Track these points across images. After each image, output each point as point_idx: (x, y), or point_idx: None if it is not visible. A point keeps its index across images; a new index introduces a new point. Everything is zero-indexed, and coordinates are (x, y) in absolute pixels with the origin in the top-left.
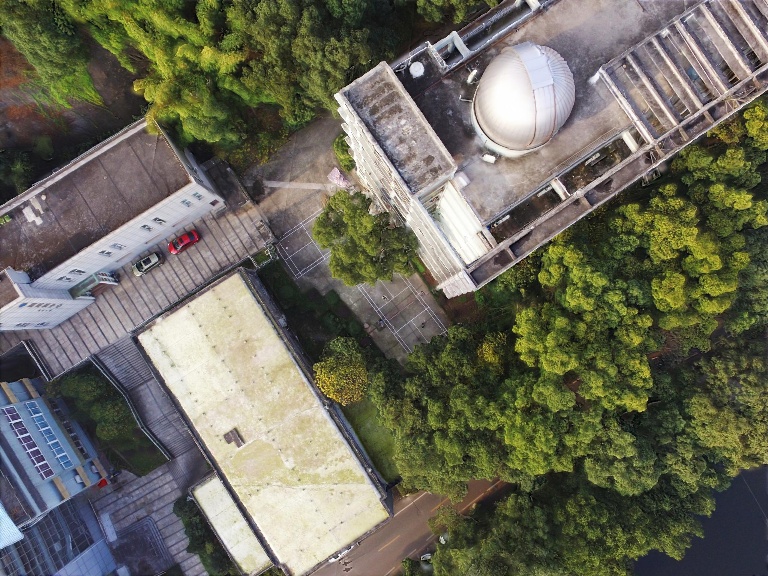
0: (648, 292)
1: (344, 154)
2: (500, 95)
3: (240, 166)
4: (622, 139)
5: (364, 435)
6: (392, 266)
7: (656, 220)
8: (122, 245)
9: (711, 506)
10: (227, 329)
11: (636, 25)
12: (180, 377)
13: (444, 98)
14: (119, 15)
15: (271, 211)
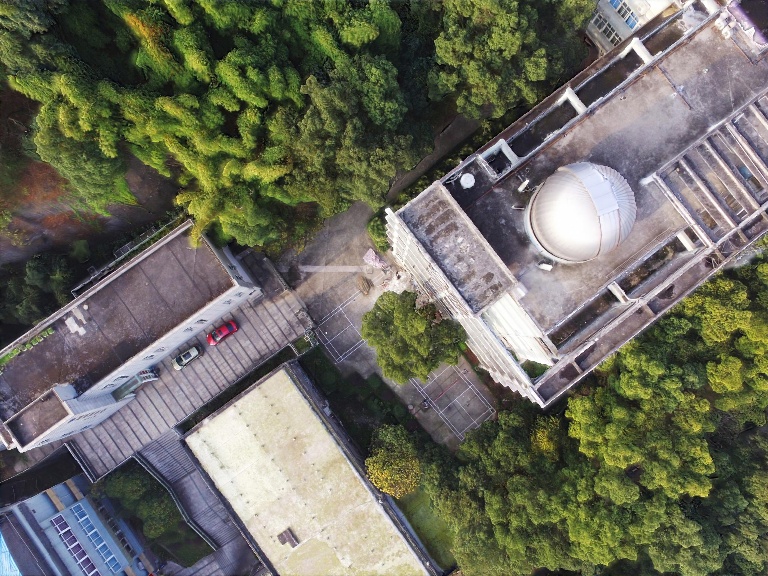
0: (703, 374)
1: (380, 237)
2: (563, 219)
3: (276, 255)
4: (676, 237)
5: (417, 522)
6: (441, 359)
7: (707, 303)
8: (165, 348)
9: None
10: (275, 427)
11: (684, 123)
12: (230, 479)
13: (496, 207)
14: (163, 137)
15: (308, 296)
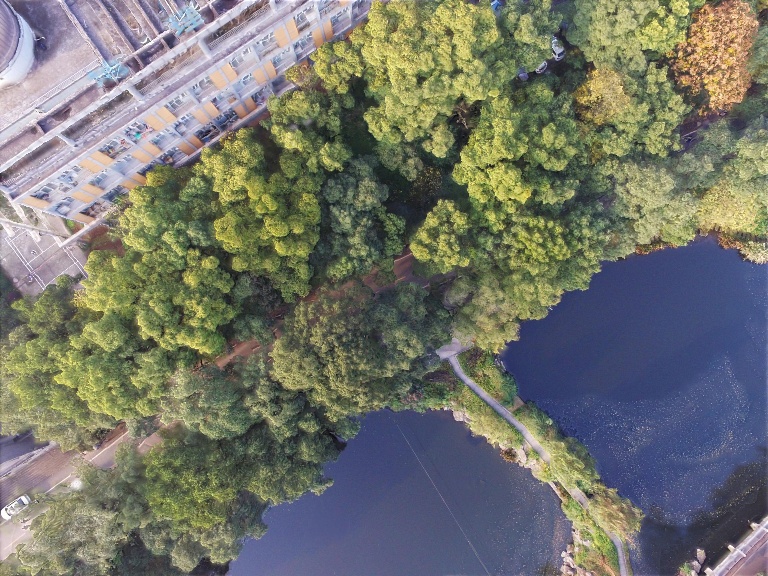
0: (215, 234)
1: None
2: None
3: None
4: None
5: None
6: None
7: None
8: None
9: (310, 450)
10: None
11: None
12: None
13: None
14: None
15: None
